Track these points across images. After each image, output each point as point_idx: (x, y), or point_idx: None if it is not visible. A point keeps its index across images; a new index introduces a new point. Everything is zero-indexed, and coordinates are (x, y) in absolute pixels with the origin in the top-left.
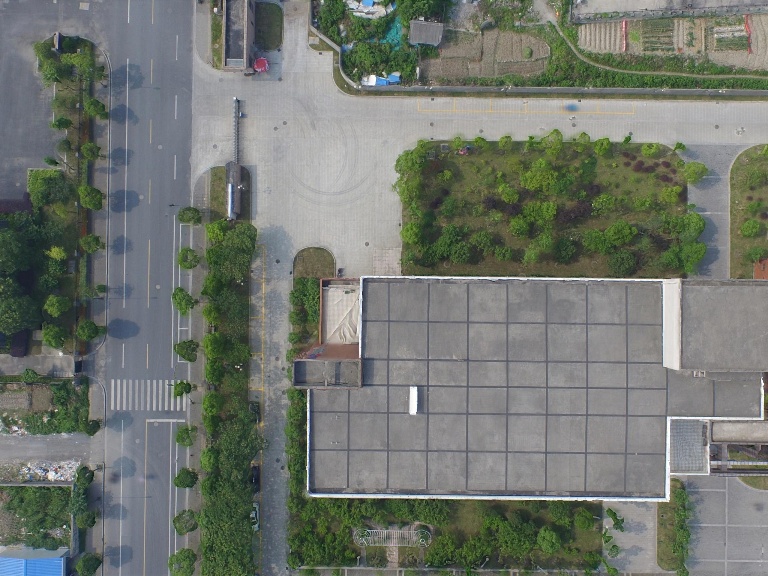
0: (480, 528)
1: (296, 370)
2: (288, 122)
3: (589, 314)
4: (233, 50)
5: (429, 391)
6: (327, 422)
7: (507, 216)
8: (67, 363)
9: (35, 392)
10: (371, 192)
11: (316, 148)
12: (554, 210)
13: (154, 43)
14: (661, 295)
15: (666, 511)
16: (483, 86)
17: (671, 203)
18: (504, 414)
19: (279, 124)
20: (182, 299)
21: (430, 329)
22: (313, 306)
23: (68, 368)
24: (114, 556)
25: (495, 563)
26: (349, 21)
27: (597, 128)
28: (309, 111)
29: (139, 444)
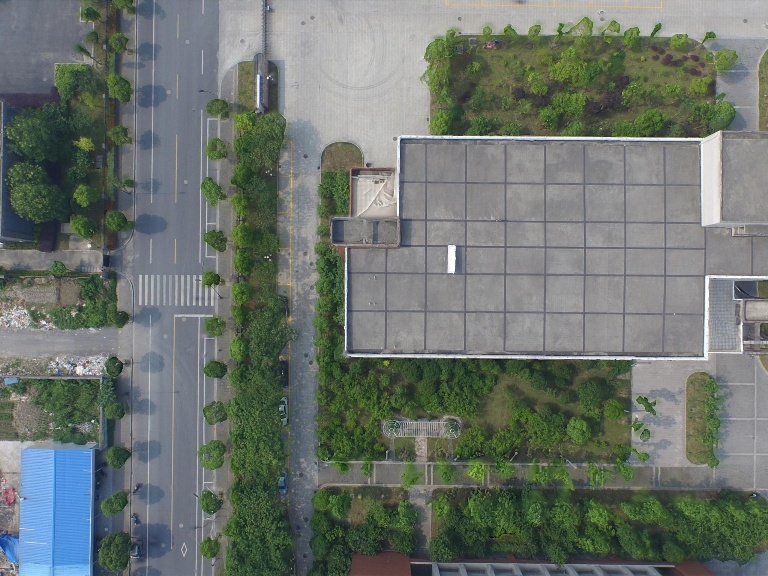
0: (509, 421)
1: (334, 230)
2: (316, 17)
3: (627, 175)
4: None
5: (467, 251)
6: (365, 283)
7: (536, 108)
8: (95, 258)
9: (63, 287)
10: (399, 87)
11: (344, 43)
12: (583, 101)
13: None
14: (699, 156)
15: (695, 405)
16: None
17: (701, 94)
18: (542, 274)
19: (307, 19)
20: (212, 187)
21: (468, 190)
22: (342, 196)
23: (96, 263)
24: (142, 451)
25: (524, 457)
26: None
27: (625, 22)
28: (337, 6)
29: (167, 339)
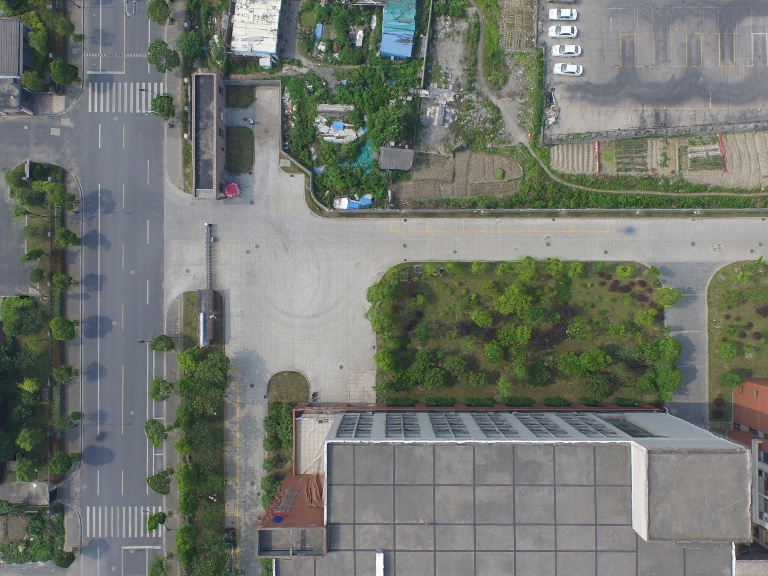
0: None
1: (261, 536)
2: (260, 245)
3: (557, 475)
4: (203, 180)
5: (396, 556)
6: None
7: (481, 340)
8: (42, 490)
9: (10, 521)
10: (345, 315)
11: (289, 271)
12: (528, 334)
13: (125, 168)
14: (630, 455)
15: None
16: (456, 208)
17: (647, 326)
18: None
19: (251, 248)
20: (154, 433)
21: (396, 492)
22: (286, 436)
23: (43, 496)
24: None
25: None
26: (320, 145)
27: (572, 247)
28: (281, 234)
29: (115, 571)
